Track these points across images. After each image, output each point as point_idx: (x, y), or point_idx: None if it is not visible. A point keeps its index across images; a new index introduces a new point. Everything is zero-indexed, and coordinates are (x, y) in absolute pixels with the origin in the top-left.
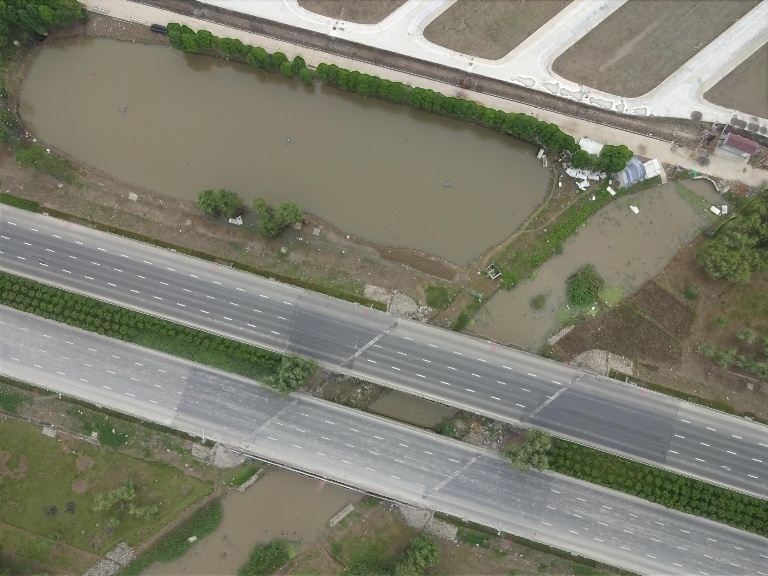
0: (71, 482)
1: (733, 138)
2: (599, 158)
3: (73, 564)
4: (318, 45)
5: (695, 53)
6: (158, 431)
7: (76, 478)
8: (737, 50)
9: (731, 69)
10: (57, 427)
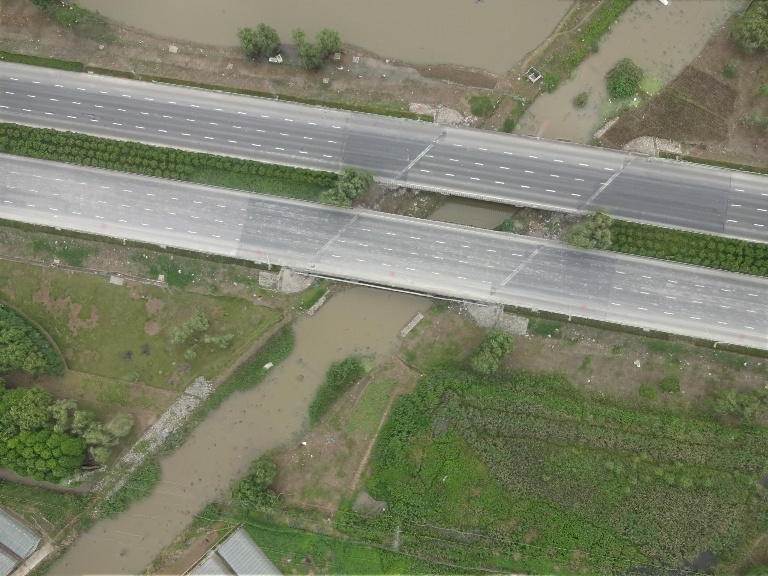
0: (143, 325)
1: None
2: None
3: (154, 403)
4: None
5: None
6: (224, 263)
7: (148, 321)
8: None
9: None
10: (124, 275)
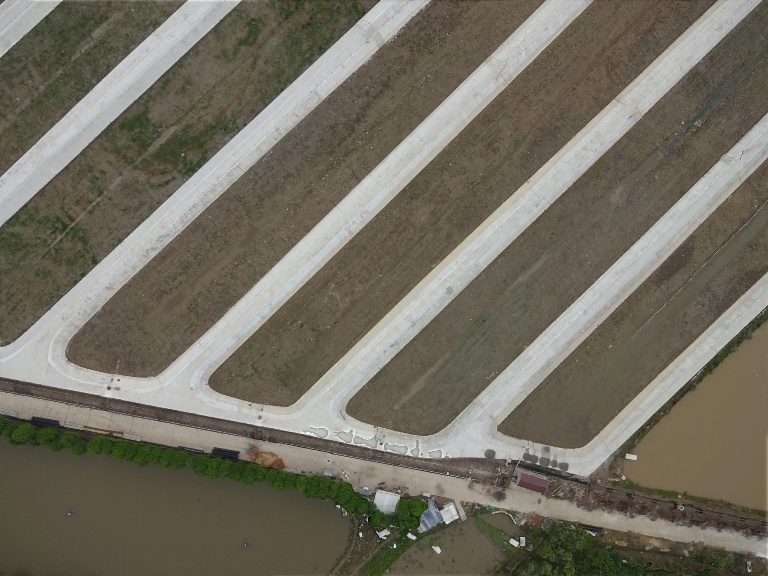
0: None
1: (524, 481)
2: (393, 520)
3: None
4: (93, 405)
5: (487, 384)
6: None
7: None
8: (526, 382)
9: (522, 399)
10: None
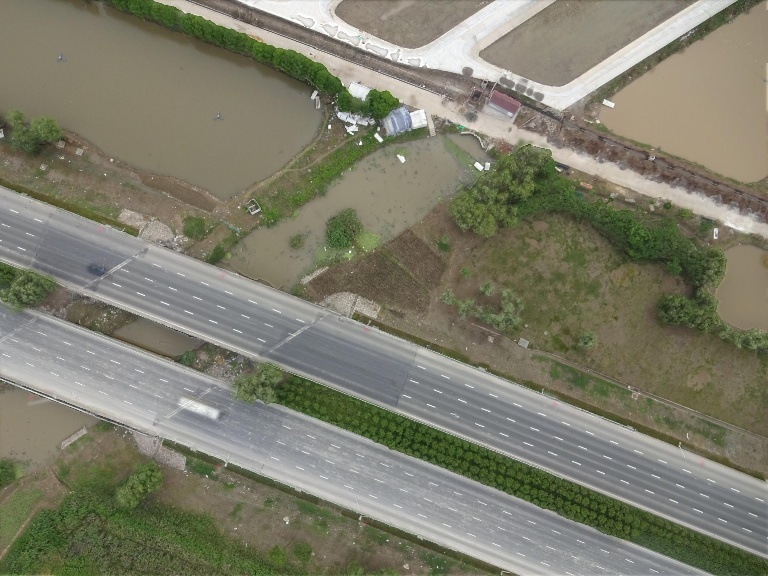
0: None
1: (497, 95)
2: (362, 101)
3: None
4: None
5: (476, 11)
6: None
7: None
8: (514, 12)
9: (508, 30)
10: None
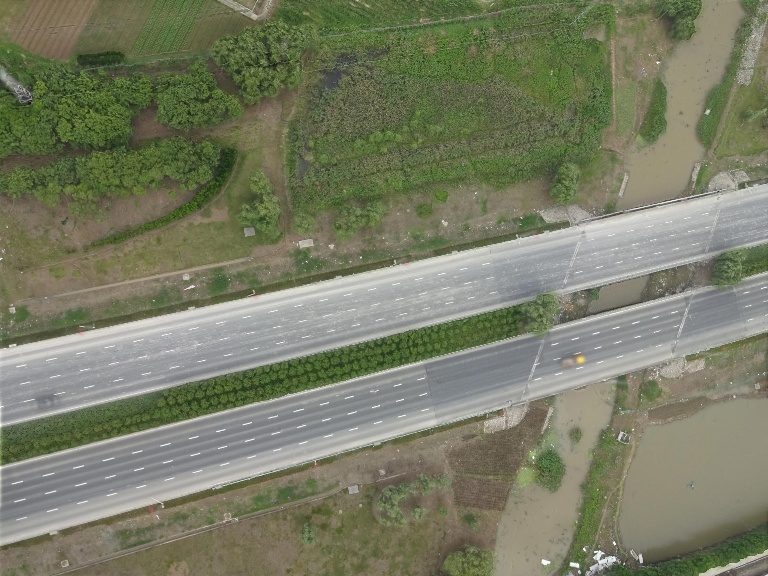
0: None
1: None
2: None
3: None
4: None
5: None
6: None
7: None
8: None
9: None
10: None
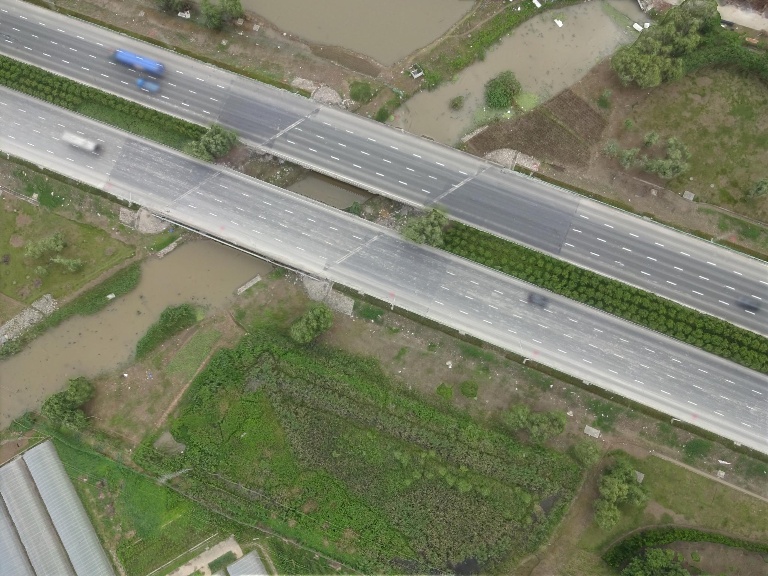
0: (9, 237)
1: None
2: None
3: (2, 310)
4: None
5: None
6: (90, 193)
7: (14, 234)
8: None
9: None
10: (4, 188)
